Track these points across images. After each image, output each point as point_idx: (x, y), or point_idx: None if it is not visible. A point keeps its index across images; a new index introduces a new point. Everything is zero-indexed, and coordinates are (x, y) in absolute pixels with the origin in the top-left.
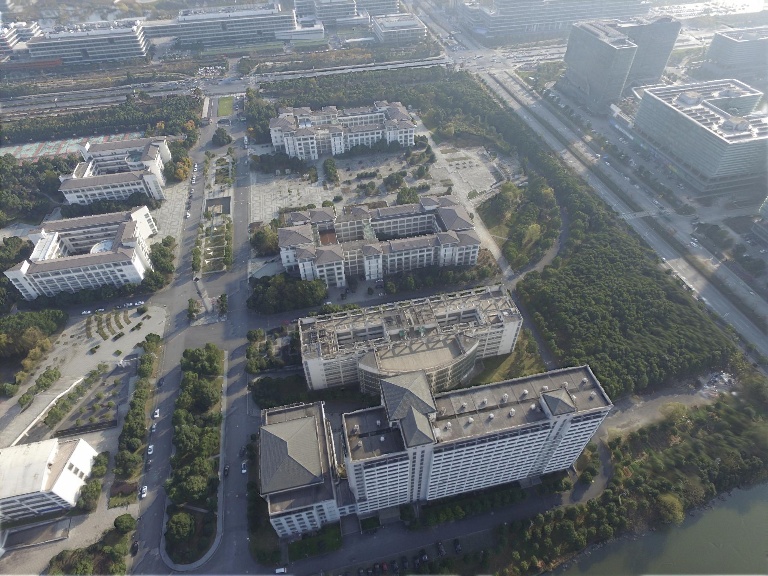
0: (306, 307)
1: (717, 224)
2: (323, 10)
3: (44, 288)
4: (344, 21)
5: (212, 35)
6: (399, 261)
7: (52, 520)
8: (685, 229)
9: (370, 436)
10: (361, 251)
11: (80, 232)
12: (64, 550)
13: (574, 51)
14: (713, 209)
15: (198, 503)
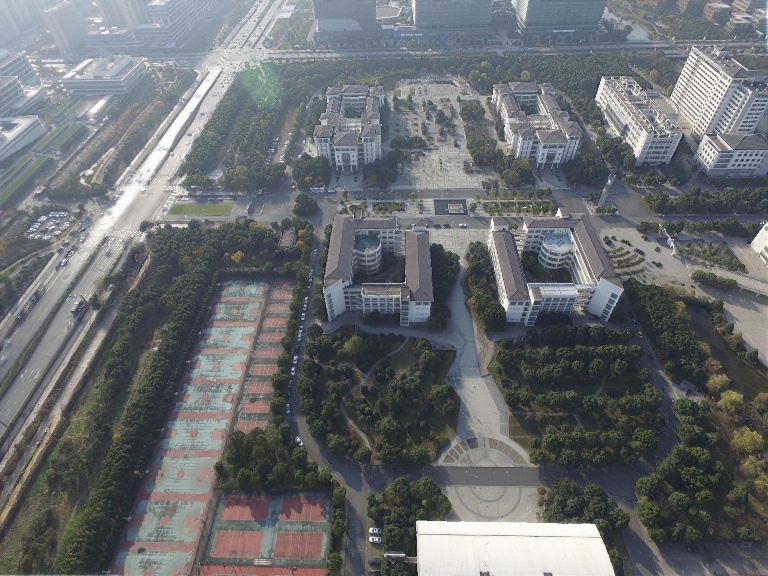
0: None
1: None
2: None
3: None
4: (25, 104)
5: None
6: None
7: None
8: None
9: (759, 88)
10: None
11: None
12: None
13: (325, 6)
14: (499, 38)
15: None
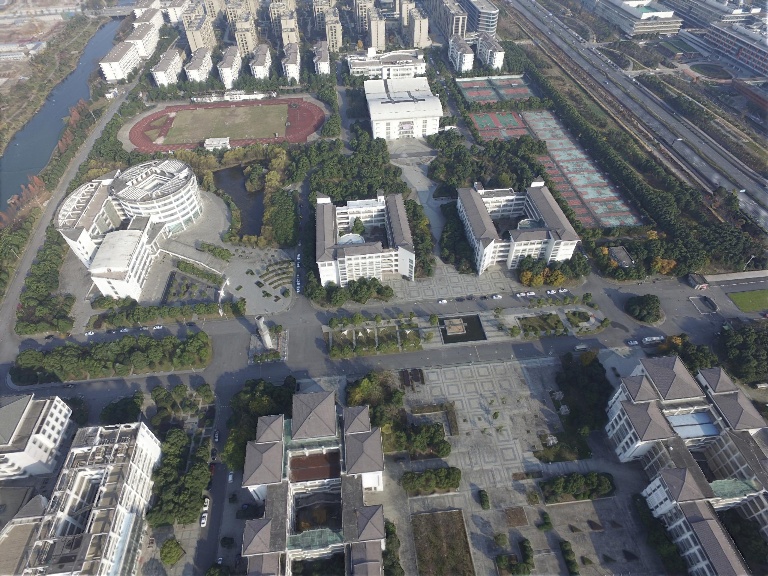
0: None
1: None
2: None
3: None
4: None
5: None
6: None
7: None
8: None
9: None
10: None
11: None
12: (70, 299)
13: None
14: None
15: None
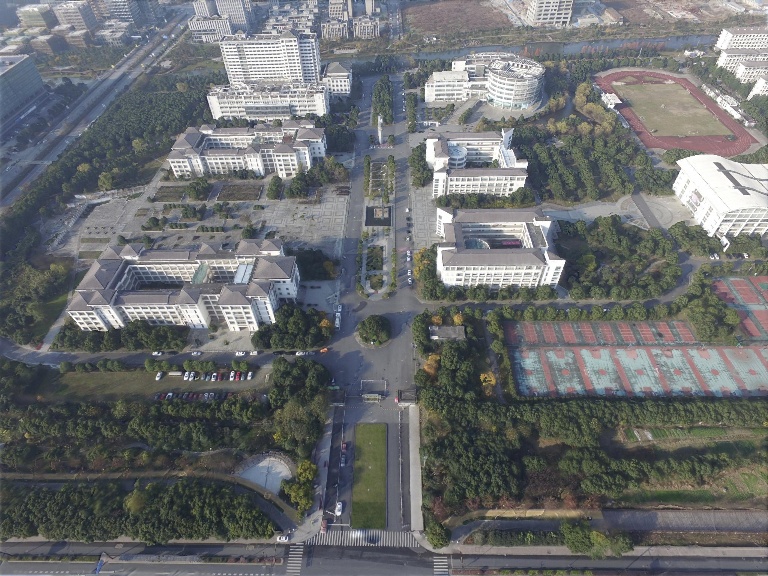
0: None
1: (3, 150)
2: None
3: None
4: None
5: None
6: None
7: None
8: (30, 150)
9: (307, 37)
10: None
11: None
12: None
13: None
14: None
15: None
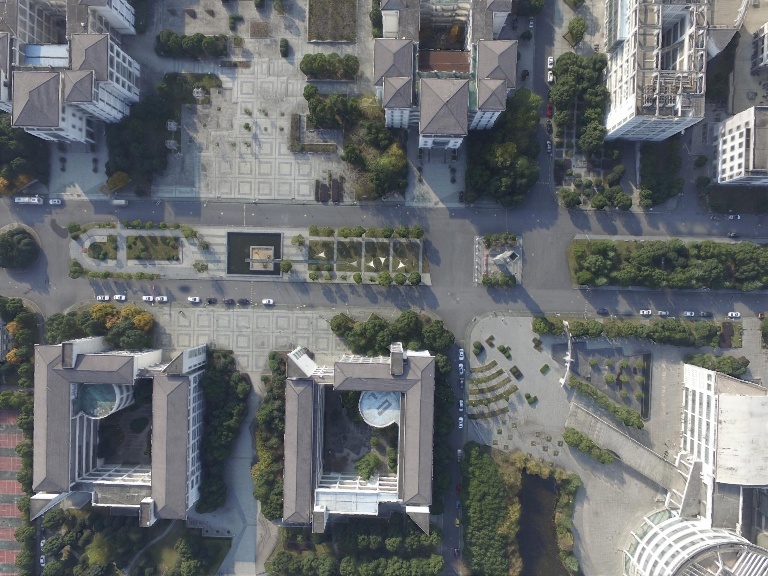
0: None
1: None
2: None
3: None
4: None
5: None
6: None
7: None
8: None
9: None
10: None
11: None
12: None
13: None
14: None
15: None
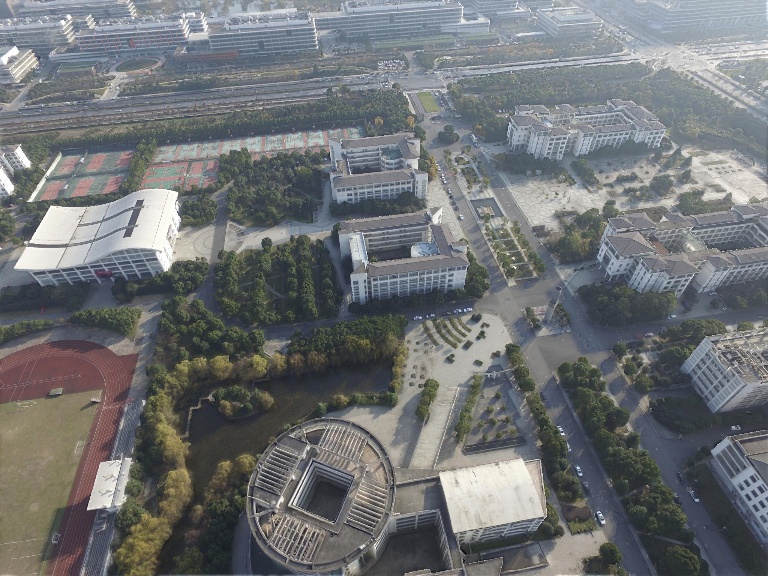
0: (651, 320)
1: None
2: (485, 3)
3: (374, 291)
4: (505, 14)
5: (378, 28)
6: (737, 273)
7: (521, 544)
8: None
9: None
10: (706, 262)
11: (379, 233)
12: None
13: None
14: None
15: (668, 533)
